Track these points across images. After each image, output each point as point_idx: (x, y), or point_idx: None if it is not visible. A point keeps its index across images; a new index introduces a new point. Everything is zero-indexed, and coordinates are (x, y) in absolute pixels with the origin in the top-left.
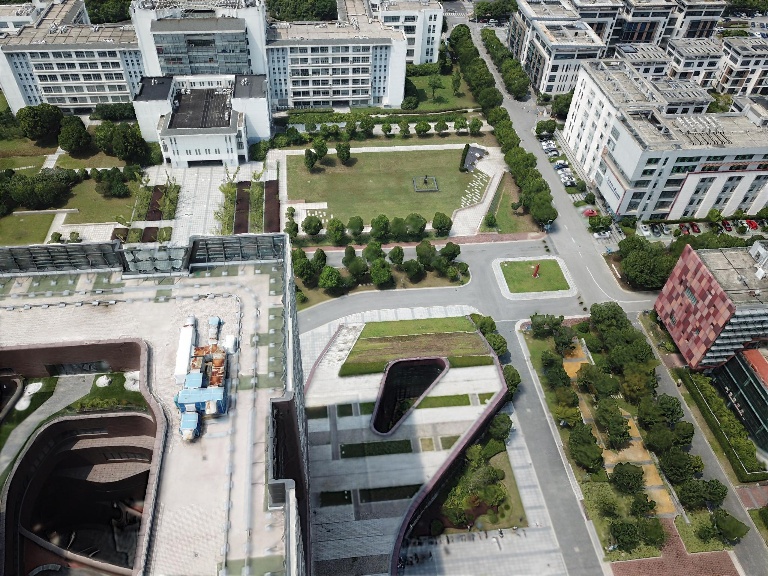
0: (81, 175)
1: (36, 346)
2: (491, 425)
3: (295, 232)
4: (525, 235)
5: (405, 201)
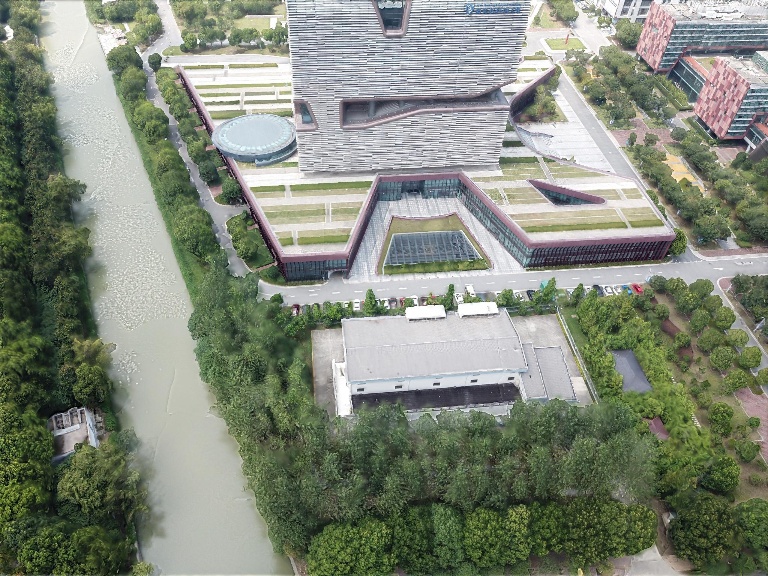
0: (278, 1)
1: None
2: (548, 84)
3: None
4: (558, 29)
5: None
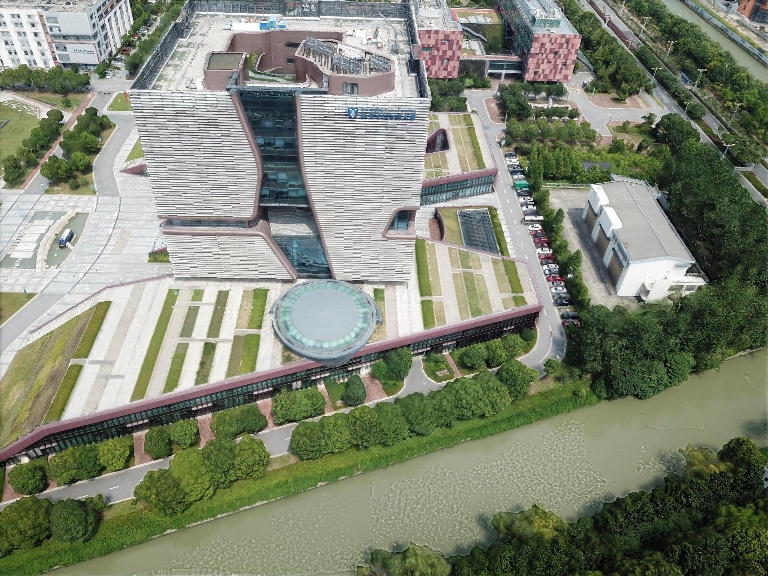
0: None
1: (226, 50)
2: None
3: (16, 170)
4: (88, 98)
5: (7, 135)
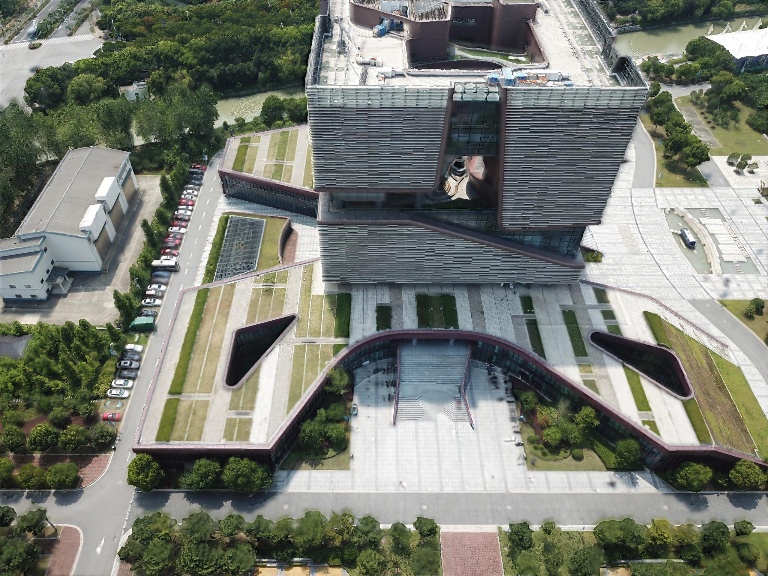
0: None
1: (536, 37)
2: None
3: None
4: None
5: None
